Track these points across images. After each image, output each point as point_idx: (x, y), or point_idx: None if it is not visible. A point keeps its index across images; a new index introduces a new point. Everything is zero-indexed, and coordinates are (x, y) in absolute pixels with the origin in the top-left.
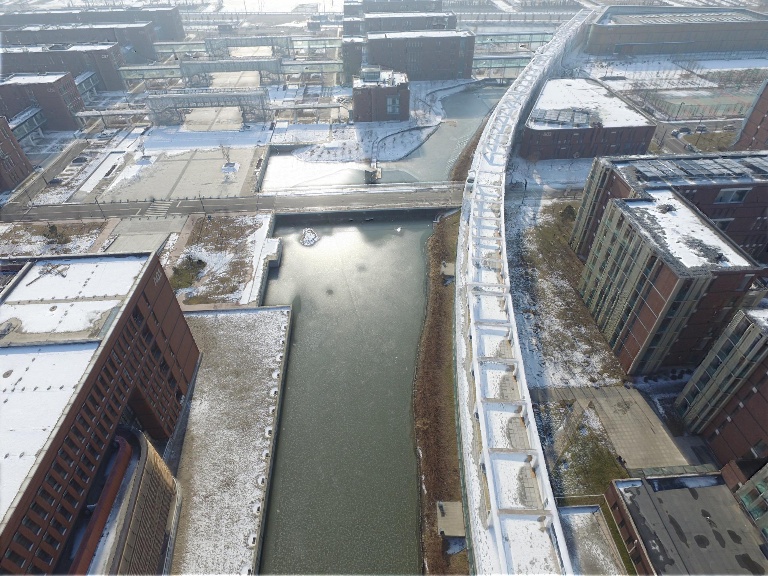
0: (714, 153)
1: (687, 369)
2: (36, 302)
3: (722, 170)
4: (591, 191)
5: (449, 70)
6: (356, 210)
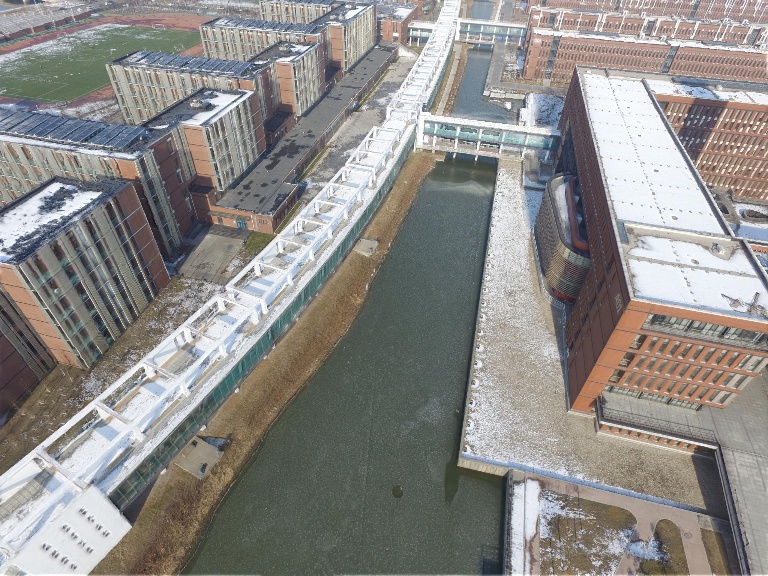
0: None
1: None
2: (722, 271)
3: None
4: None
5: None
6: None
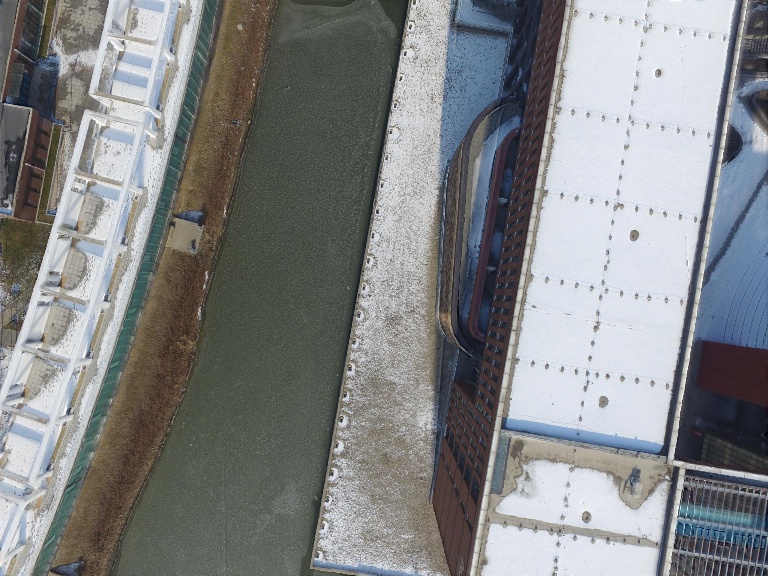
0: None
1: None
2: (615, 537)
3: None
4: None
5: None
6: None
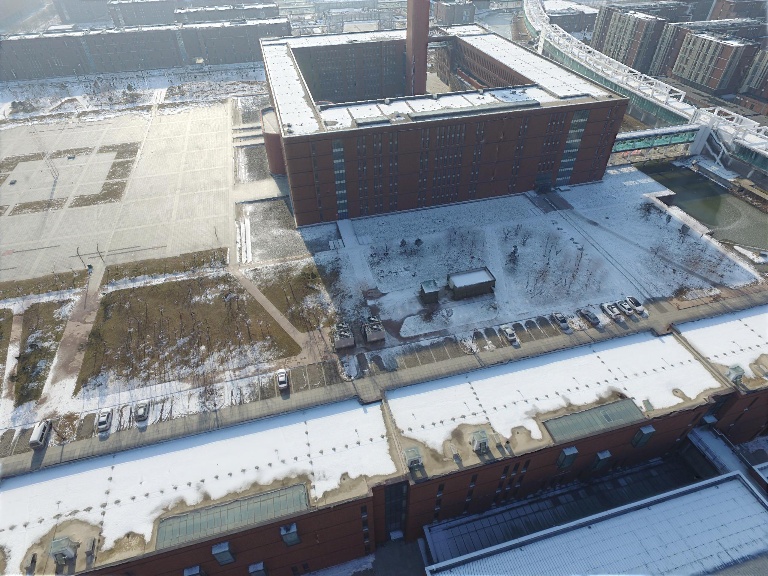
0: None
1: None
2: None
3: (649, 4)
4: (599, 21)
5: (477, 4)
6: None
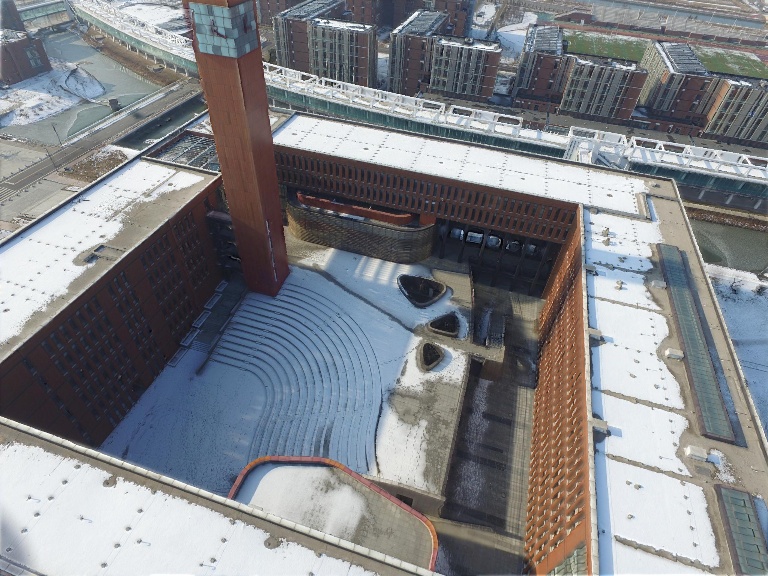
0: (302, 3)
1: (375, 87)
2: None
3: (318, 6)
4: (281, 37)
5: None
6: (157, 116)
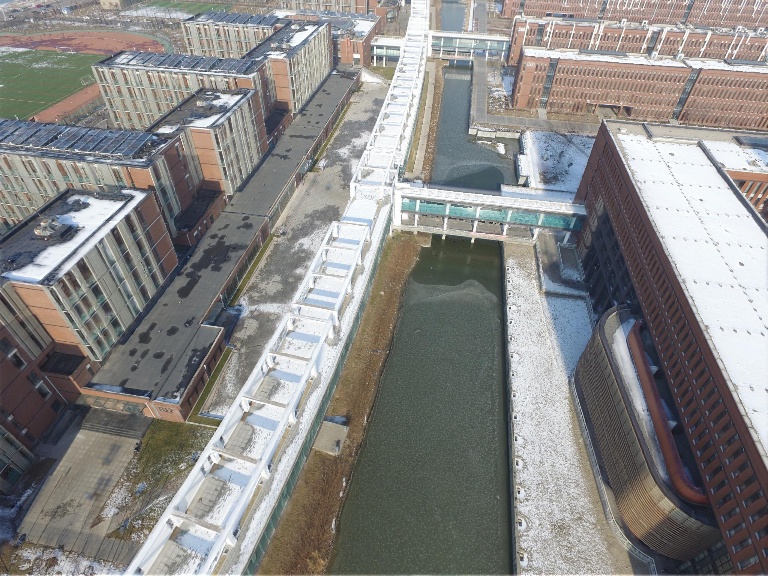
0: None
1: None
2: None
3: None
4: None
5: None
6: None
